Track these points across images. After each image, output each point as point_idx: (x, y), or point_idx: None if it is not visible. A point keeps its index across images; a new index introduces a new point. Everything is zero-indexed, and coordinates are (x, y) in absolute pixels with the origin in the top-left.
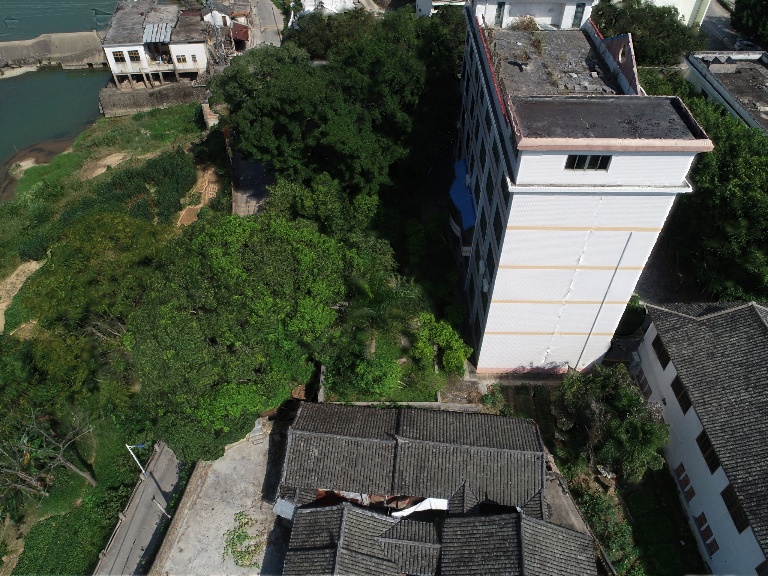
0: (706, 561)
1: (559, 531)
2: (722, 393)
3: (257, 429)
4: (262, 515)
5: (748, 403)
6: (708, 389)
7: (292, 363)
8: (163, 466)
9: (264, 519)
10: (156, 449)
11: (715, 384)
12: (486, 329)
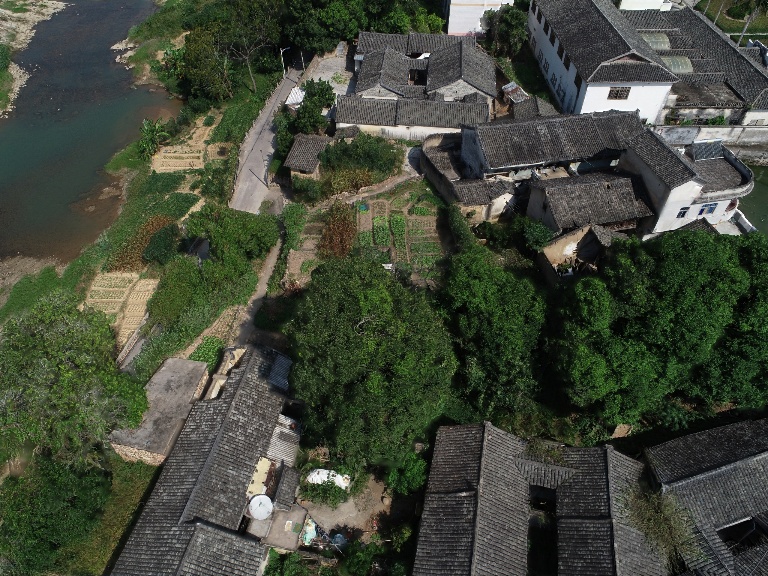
0: (546, 78)
1: (479, 52)
2: (552, 3)
3: (341, 50)
4: (346, 74)
5: (562, 2)
6: (547, 3)
7: (360, 8)
8: (292, 76)
9: (348, 75)
10: (288, 70)
11: (550, 1)
12: (451, 1)
